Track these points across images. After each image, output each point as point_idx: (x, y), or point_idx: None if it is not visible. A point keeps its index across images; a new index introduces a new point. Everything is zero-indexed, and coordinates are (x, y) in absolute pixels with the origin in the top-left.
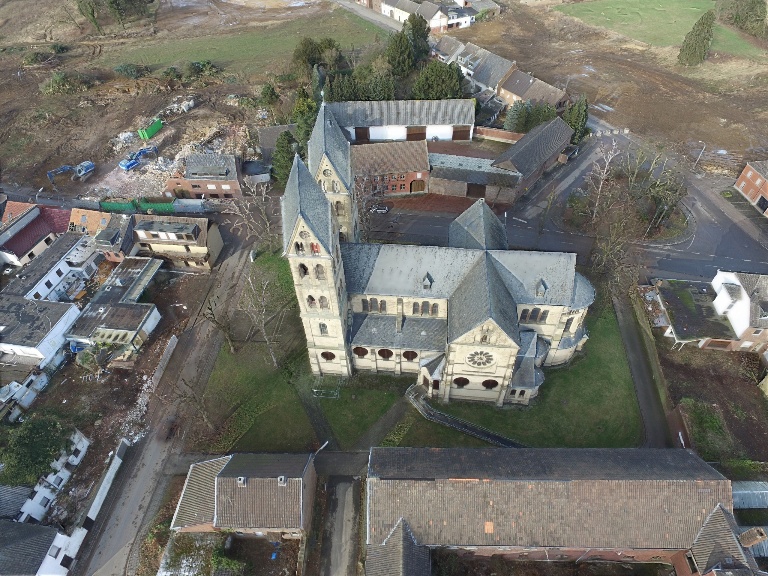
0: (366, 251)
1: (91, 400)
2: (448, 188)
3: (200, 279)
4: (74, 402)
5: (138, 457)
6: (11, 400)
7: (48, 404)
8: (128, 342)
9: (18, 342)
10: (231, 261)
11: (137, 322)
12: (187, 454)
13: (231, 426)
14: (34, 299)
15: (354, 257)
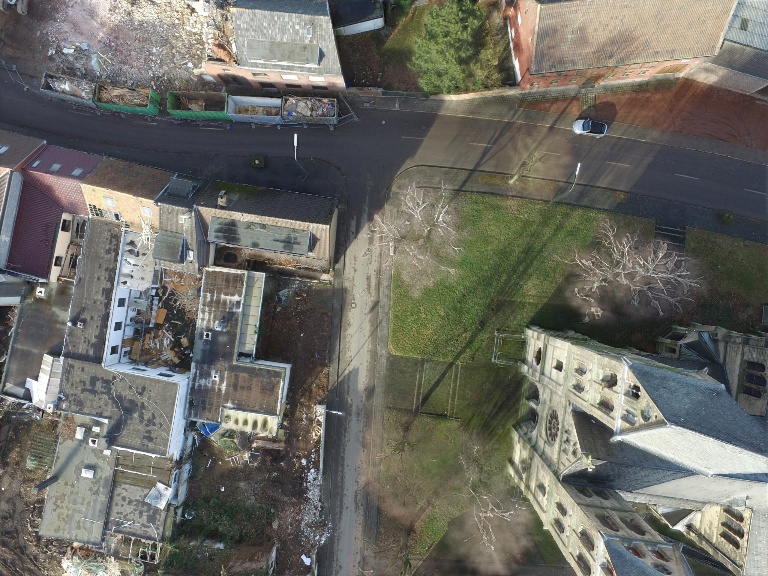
0: (666, 474)
1: (252, 488)
2: (727, 79)
3: (322, 290)
4: (234, 490)
5: (332, 558)
6: (169, 506)
7: (206, 492)
8: (274, 434)
9: (139, 446)
10: (358, 251)
11: (273, 401)
12: (382, 558)
13: (423, 531)
14: (119, 371)
15: (642, 474)
